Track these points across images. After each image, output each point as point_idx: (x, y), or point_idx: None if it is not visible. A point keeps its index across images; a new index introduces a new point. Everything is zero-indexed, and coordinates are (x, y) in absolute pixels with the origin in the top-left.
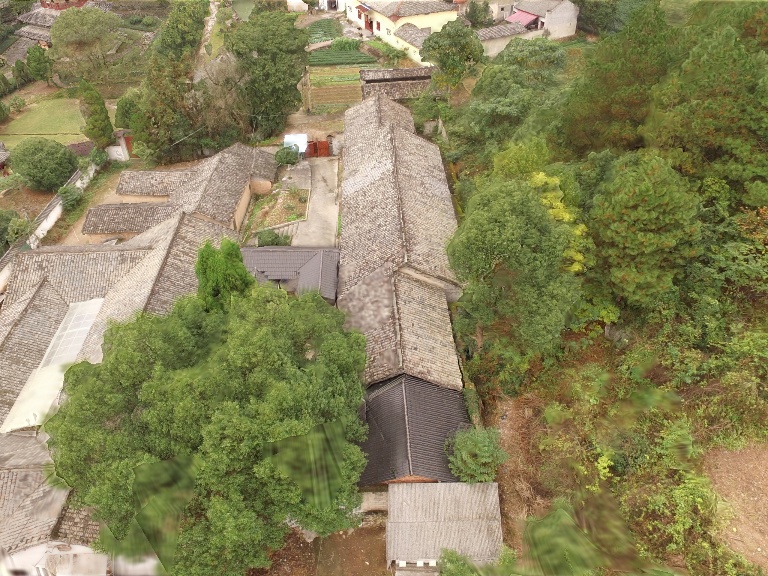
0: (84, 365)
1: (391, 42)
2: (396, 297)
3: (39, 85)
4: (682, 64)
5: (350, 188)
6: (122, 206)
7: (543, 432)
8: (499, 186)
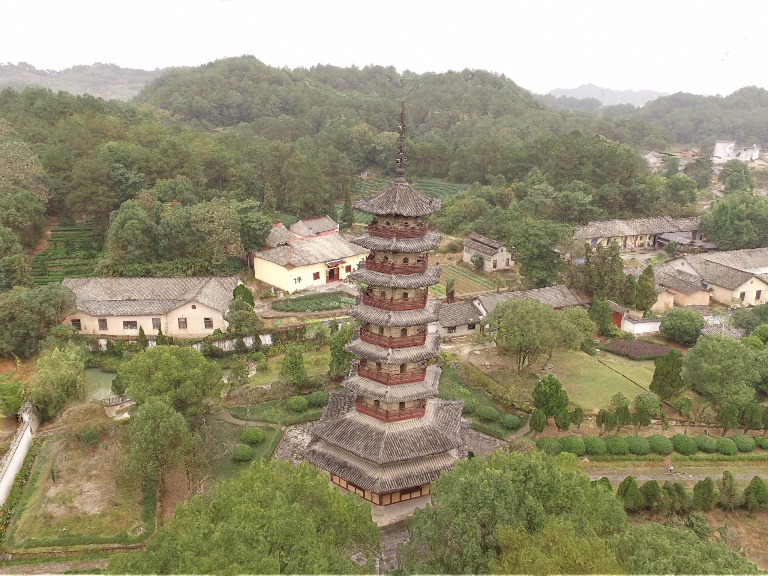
0: None
1: None
2: None
3: (551, 434)
4: None
5: (632, 232)
6: (686, 285)
7: None
8: (679, 176)
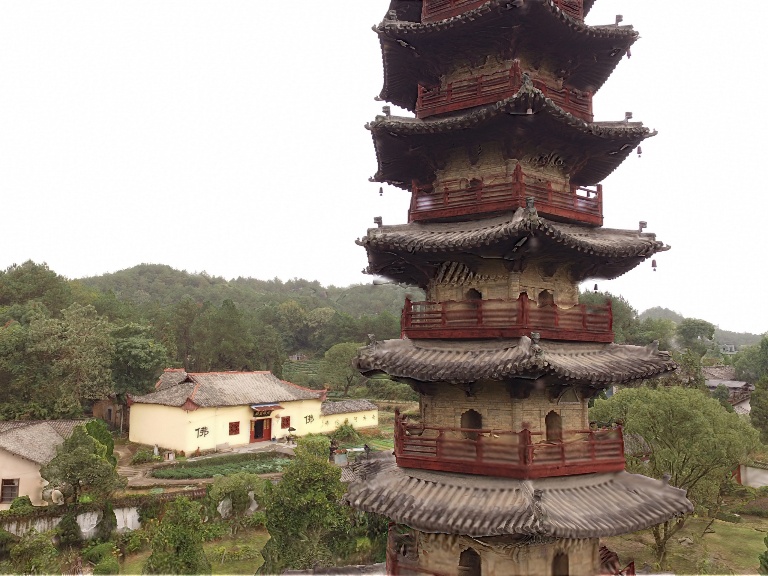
0: None
1: (314, 430)
2: None
3: None
4: (618, 303)
5: None
6: None
7: None
8: None
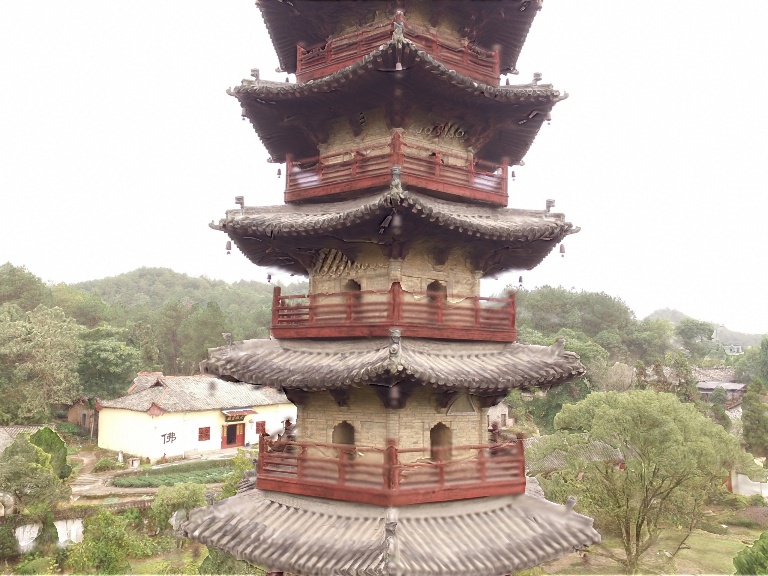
0: None
1: None
2: None
3: None
4: None
5: None
6: None
7: None
8: (690, 318)
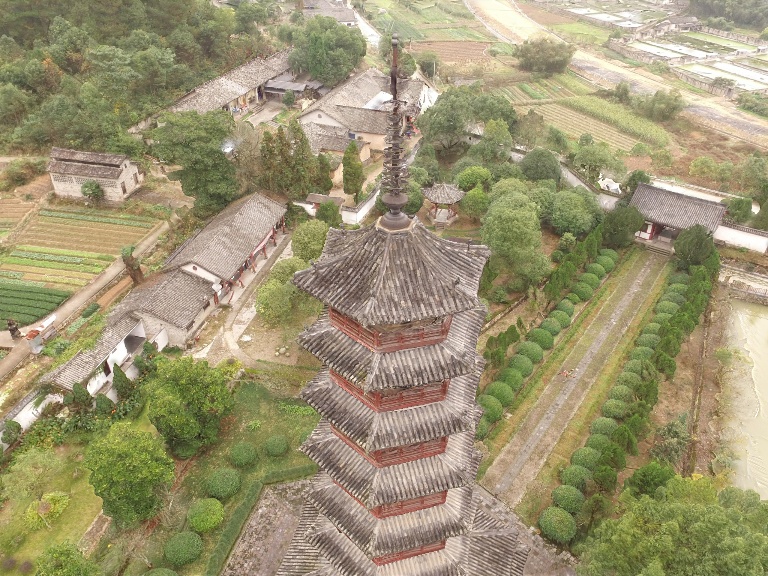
0: (356, 38)
1: None
2: (270, 58)
3: None
4: None
5: None
6: (348, 143)
7: (260, 54)
8: (248, 4)
